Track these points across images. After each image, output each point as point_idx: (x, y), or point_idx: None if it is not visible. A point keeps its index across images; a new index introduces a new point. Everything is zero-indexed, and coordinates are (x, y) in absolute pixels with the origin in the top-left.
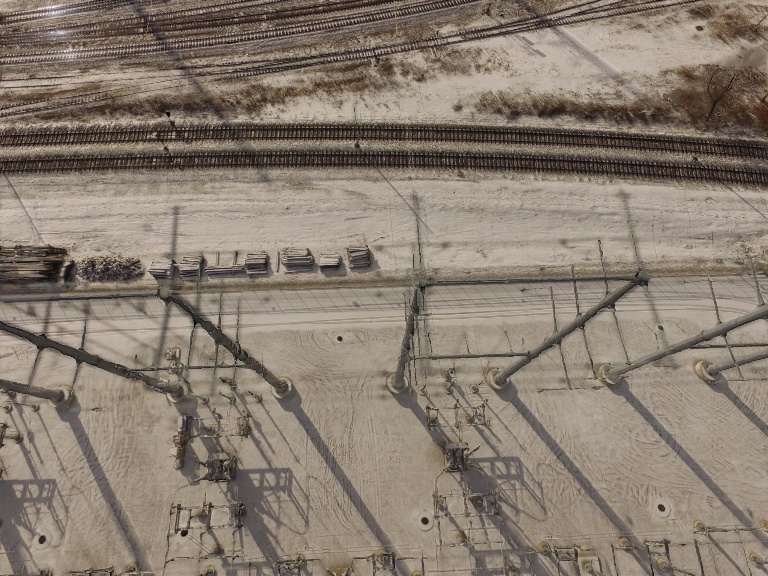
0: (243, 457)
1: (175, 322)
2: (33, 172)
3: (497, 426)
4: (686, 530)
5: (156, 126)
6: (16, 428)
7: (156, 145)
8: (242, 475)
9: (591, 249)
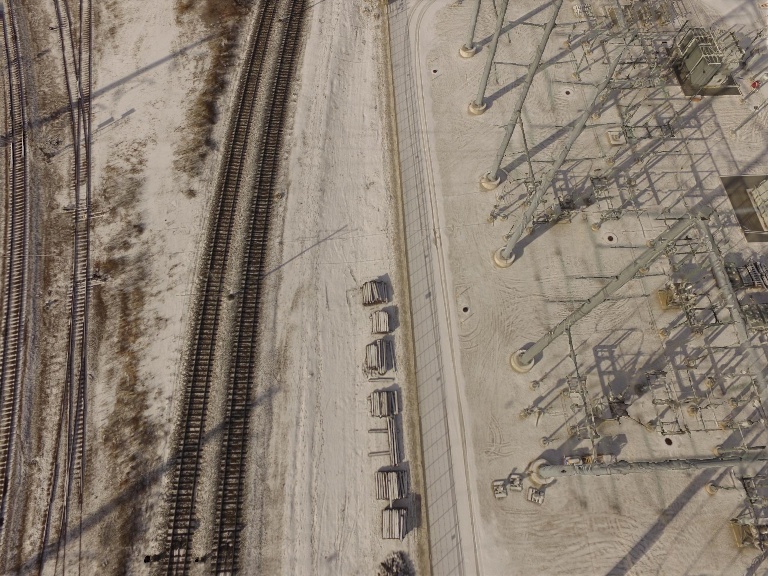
0: (592, 394)
1: (462, 495)
2: None
3: None
4: None
5: None
6: None
7: None
8: None
9: (366, 104)
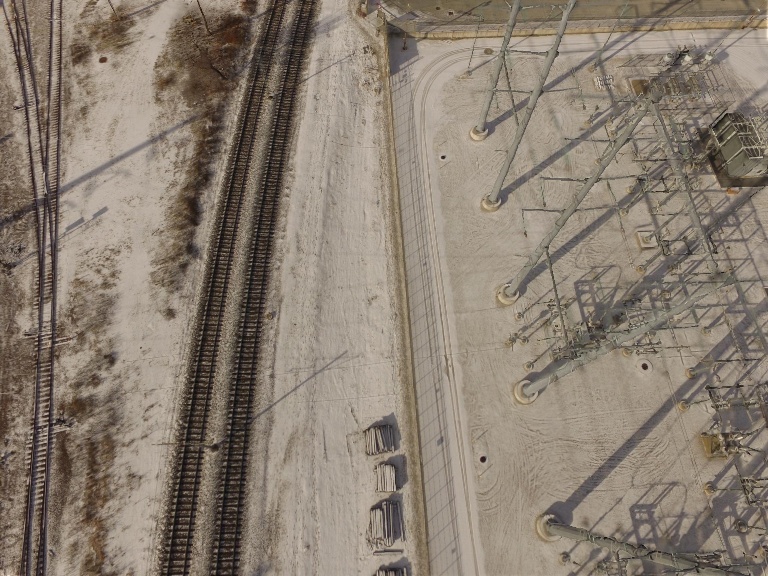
0: (631, 569)
1: None
2: None
3: None
4: None
5: None
6: None
7: None
8: (649, 567)
9: (367, 199)
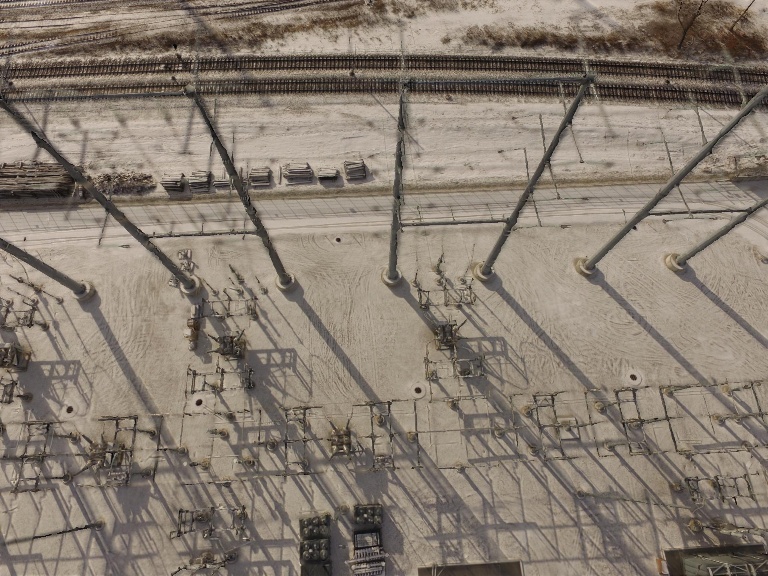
0: (251, 340)
1: (186, 228)
2: (50, 100)
3: (483, 311)
4: (655, 395)
5: (164, 59)
6: (42, 318)
7: (164, 75)
8: (251, 355)
9: (570, 161)
